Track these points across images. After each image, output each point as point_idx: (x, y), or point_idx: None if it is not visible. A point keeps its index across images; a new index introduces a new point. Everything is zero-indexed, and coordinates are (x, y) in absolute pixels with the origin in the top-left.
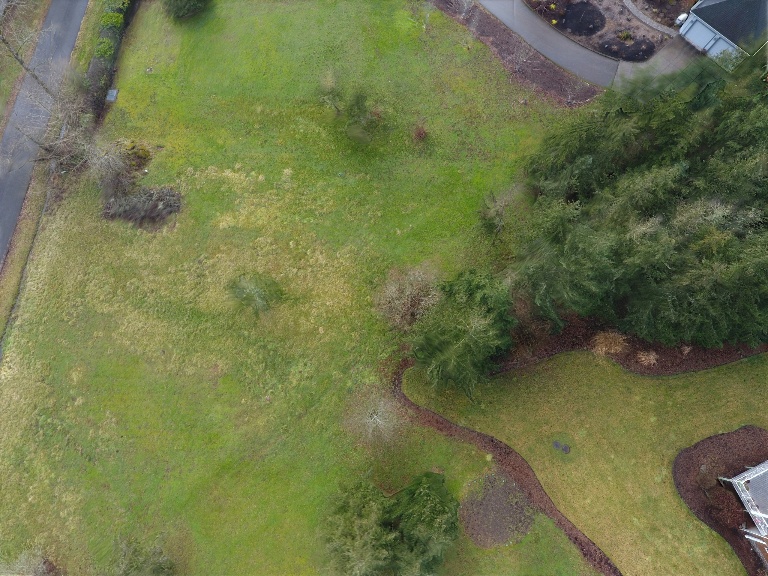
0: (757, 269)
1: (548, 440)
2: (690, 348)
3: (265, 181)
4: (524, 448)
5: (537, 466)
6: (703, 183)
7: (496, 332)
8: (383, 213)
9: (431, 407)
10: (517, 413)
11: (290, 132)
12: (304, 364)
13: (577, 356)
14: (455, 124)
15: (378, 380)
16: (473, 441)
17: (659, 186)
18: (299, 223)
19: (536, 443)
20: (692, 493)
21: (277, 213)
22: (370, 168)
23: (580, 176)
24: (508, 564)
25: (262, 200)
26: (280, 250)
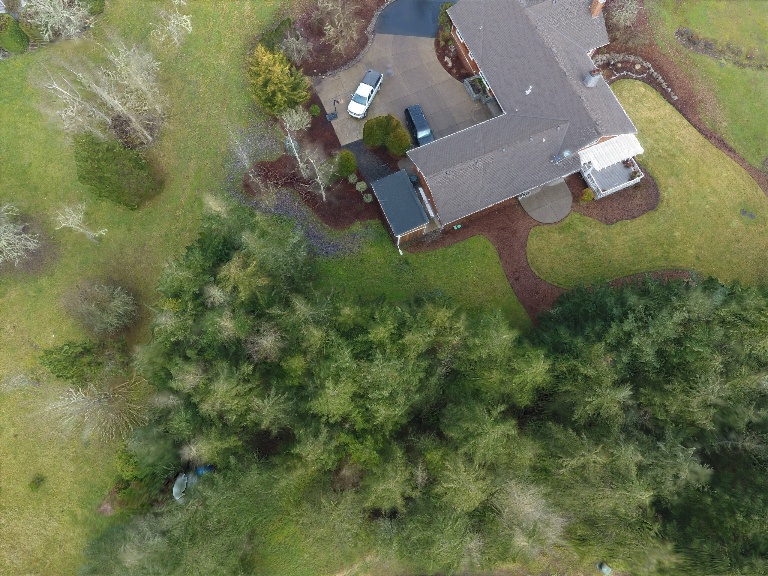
0: None
1: (759, 220)
2: None
3: None
4: None
5: (765, 200)
6: None
7: None
8: None
9: None
10: None
11: None
12: None
13: None
14: None
15: None
16: None
17: None
18: None
19: None
20: None
21: None
22: None
23: None
24: None
25: None
26: None
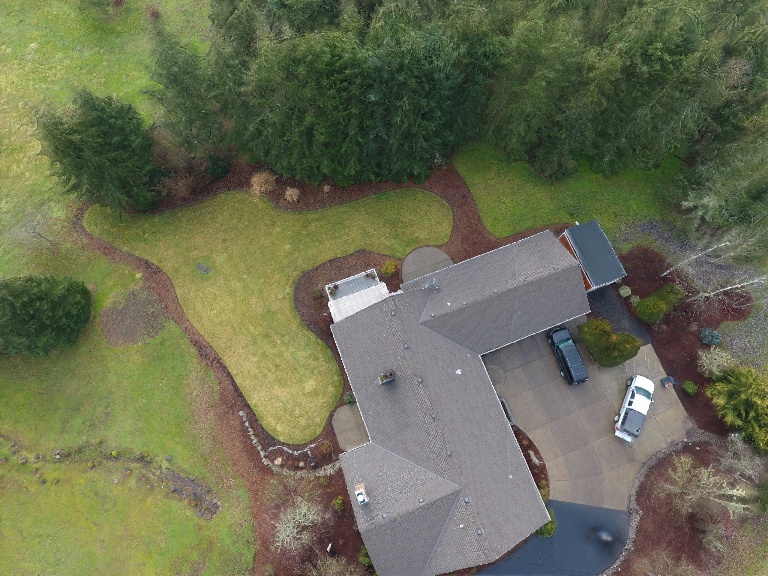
0: (279, 67)
1: (193, 263)
2: (329, 187)
3: (11, 53)
4: (171, 269)
5: (178, 283)
6: (281, 11)
7: (101, 139)
8: (106, 80)
9: (103, 236)
10: (173, 241)
11: (44, 13)
12: (6, 202)
13: (236, 195)
14: (184, 5)
15: (64, 214)
16: (130, 263)
17: (244, 13)
18: (31, 87)
19: (182, 265)
20: (308, 308)
21: (15, 79)
22: (105, 43)
23: (219, 22)
24: (132, 360)
25: (4, 68)
26: (9, 109)
